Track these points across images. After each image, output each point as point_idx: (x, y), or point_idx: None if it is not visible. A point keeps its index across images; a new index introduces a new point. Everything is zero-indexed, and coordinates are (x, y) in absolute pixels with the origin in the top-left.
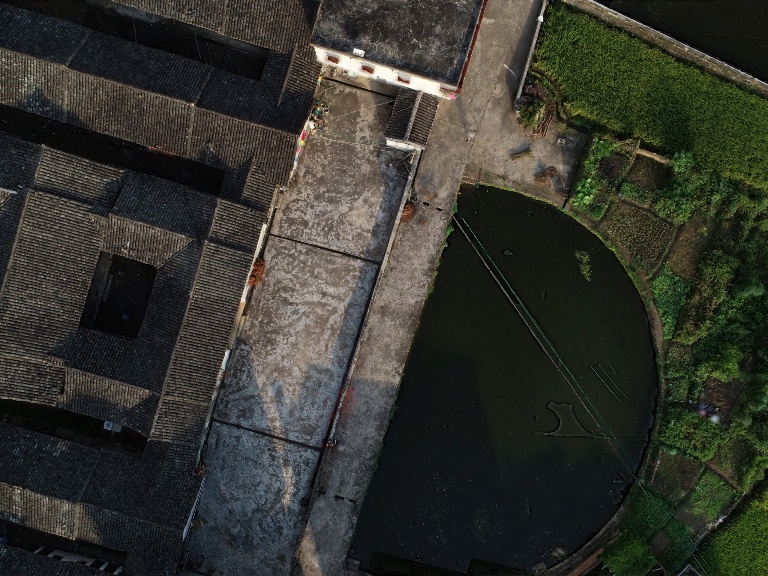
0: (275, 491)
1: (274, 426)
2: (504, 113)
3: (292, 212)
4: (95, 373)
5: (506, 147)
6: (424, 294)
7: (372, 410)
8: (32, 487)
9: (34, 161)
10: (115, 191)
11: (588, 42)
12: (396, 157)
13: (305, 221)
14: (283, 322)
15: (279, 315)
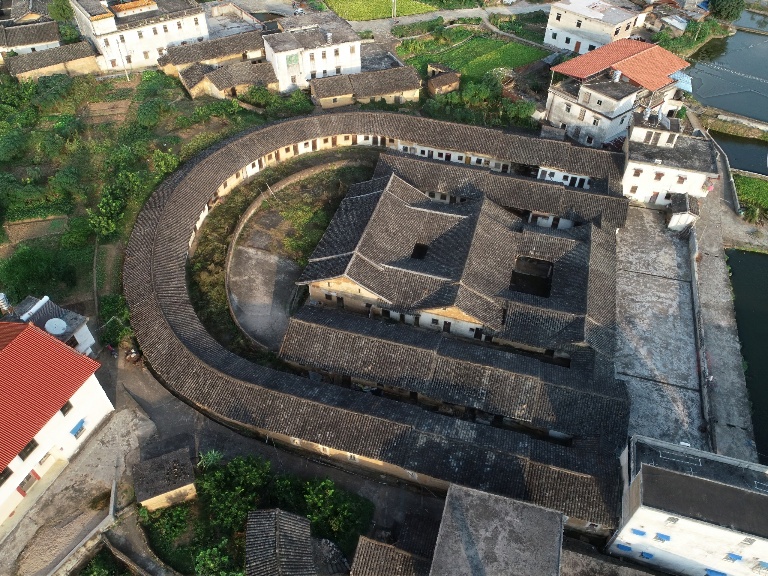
0: (673, 420)
1: (654, 374)
2: (732, 217)
3: (619, 257)
4: (532, 305)
5: (743, 230)
6: (730, 297)
7: (728, 364)
8: (501, 368)
9: (478, 204)
10: (519, 227)
11: (766, 188)
12: (676, 234)
13: (630, 261)
14: (636, 311)
15: (631, 308)
